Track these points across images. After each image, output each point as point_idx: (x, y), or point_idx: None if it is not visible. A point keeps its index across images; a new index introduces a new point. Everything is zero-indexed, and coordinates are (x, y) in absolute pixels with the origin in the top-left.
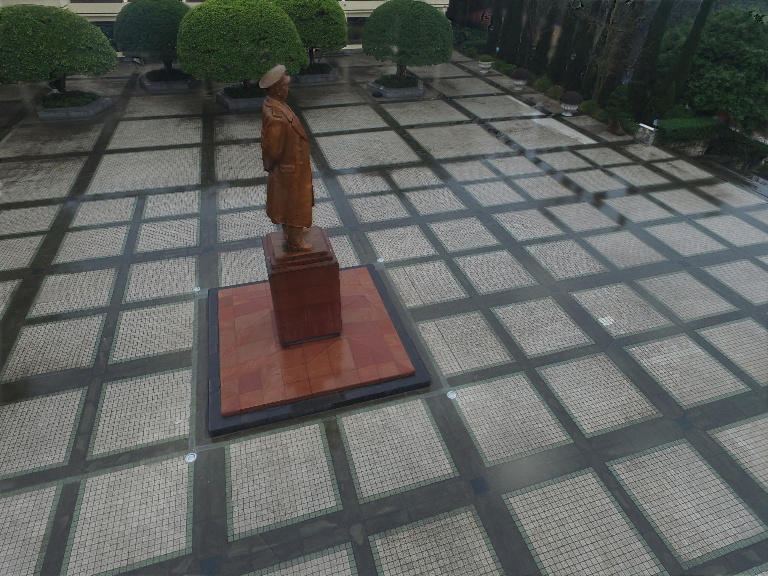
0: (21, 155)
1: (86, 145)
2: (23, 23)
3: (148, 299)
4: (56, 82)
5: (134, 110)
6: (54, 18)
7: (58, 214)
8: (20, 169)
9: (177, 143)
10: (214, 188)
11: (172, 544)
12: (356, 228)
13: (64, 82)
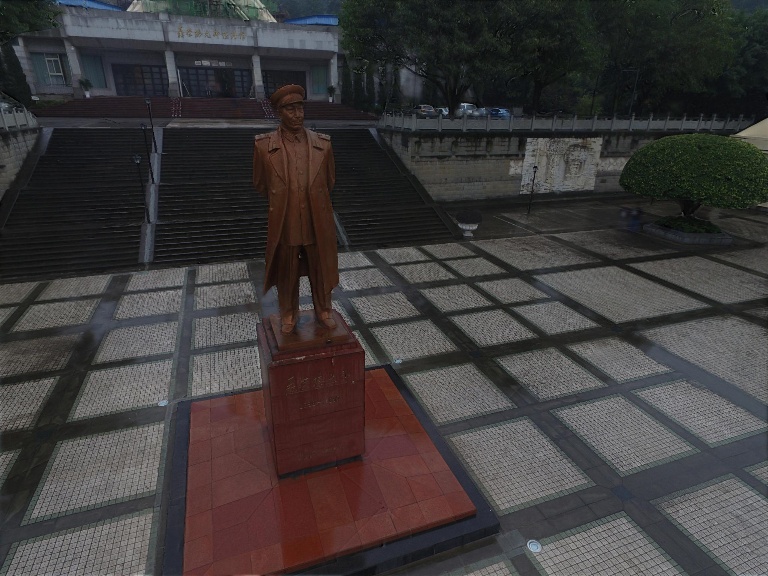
0: (571, 241)
1: (622, 255)
2: (681, 146)
3: (377, 338)
4: (687, 206)
5: (737, 255)
6: (717, 147)
7: (491, 274)
8: (549, 247)
9: (698, 291)
10: (616, 333)
11: (82, 411)
12: (628, 496)
13: (695, 209)
